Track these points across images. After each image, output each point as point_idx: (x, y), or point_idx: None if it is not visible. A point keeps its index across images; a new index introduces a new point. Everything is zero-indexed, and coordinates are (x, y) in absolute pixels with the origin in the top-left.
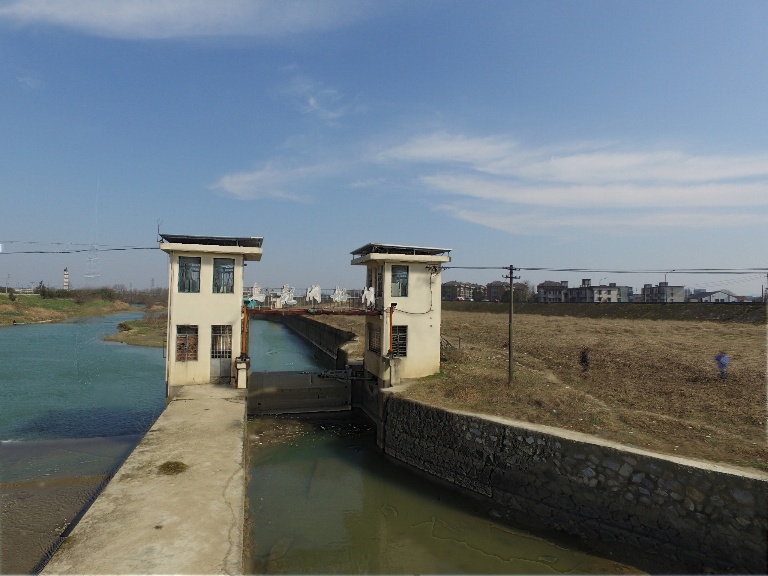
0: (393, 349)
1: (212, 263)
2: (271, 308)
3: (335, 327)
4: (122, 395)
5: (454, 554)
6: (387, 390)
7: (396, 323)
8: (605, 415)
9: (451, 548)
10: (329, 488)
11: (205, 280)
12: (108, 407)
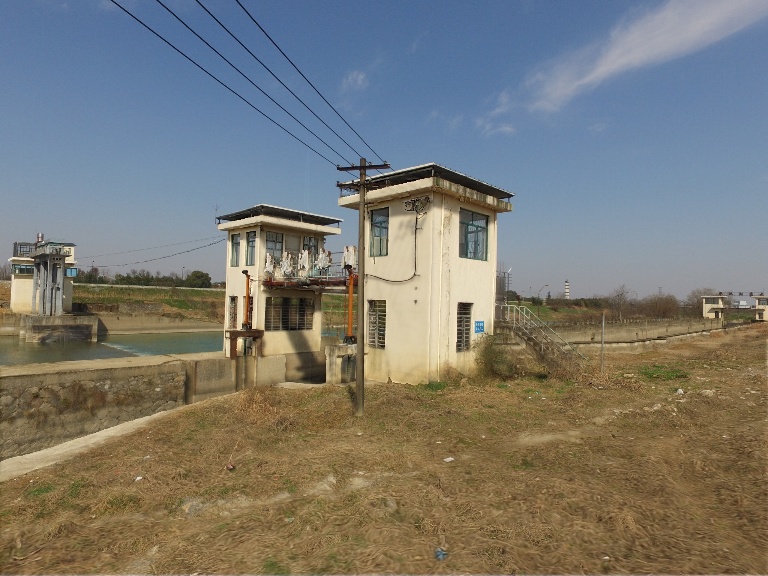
0: (373, 335)
1: (245, 237)
2: (280, 279)
3: (732, 339)
4: None
5: None
6: (282, 384)
7: (373, 296)
8: (93, 501)
9: None
10: None
11: (242, 254)
12: None
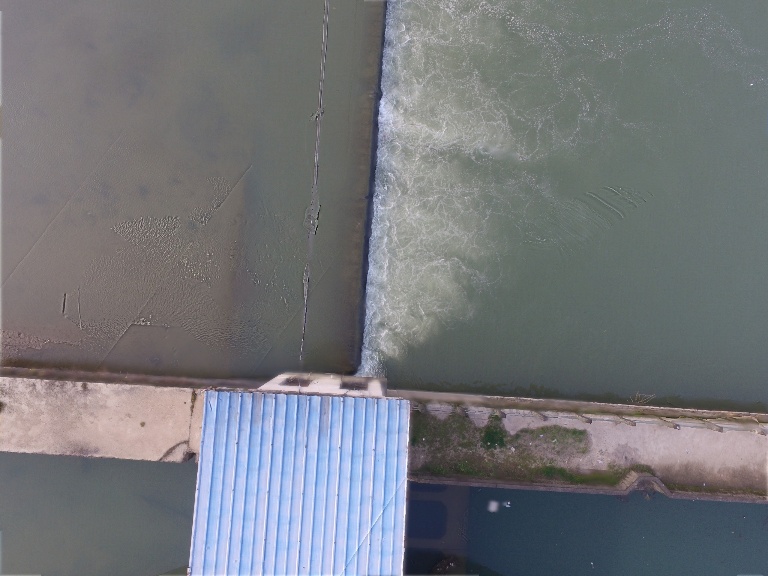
0: None
1: None
2: None
3: None
4: (555, 284)
5: (26, 567)
6: None
7: None
8: None
9: (32, 568)
10: (150, 510)
11: None
12: (532, 271)
